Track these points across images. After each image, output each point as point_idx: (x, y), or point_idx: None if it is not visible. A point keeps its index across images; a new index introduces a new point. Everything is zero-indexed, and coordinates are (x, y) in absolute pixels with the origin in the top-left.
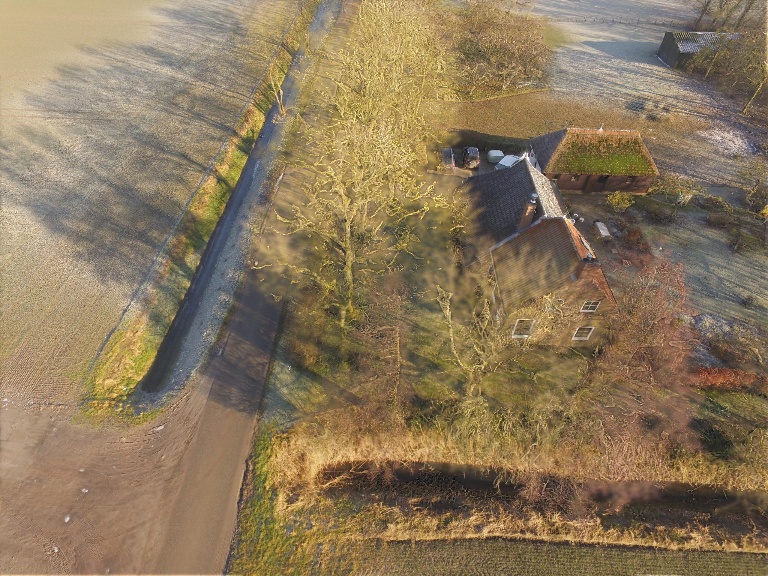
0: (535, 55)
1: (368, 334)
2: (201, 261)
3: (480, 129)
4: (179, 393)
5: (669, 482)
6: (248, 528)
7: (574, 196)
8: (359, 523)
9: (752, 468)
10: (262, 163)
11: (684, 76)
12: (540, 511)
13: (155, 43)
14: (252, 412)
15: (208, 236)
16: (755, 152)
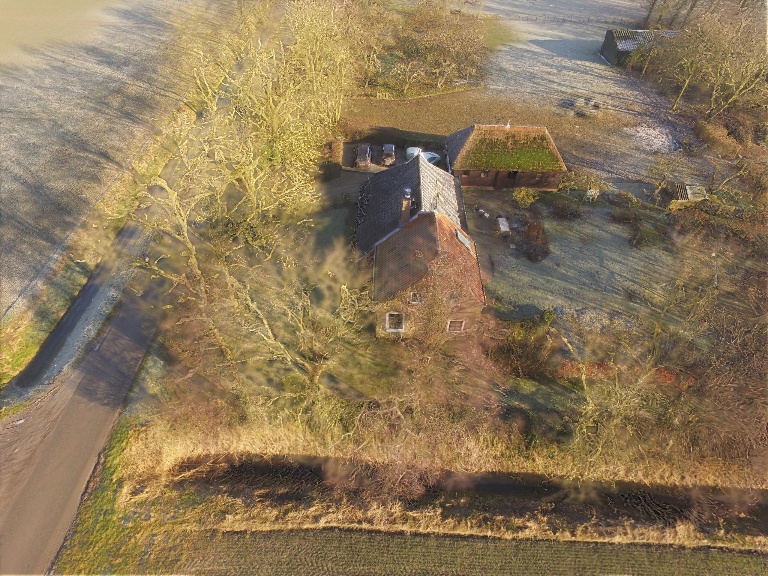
0: (470, 53)
1: (248, 329)
2: (103, 258)
3: (406, 127)
4: (47, 388)
5: (525, 473)
6: (86, 520)
7: (485, 192)
8: (198, 514)
9: (581, 457)
10: (182, 161)
11: (623, 74)
12: (382, 502)
13: (99, 43)
14: (115, 406)
15: (114, 233)
16: (677, 148)
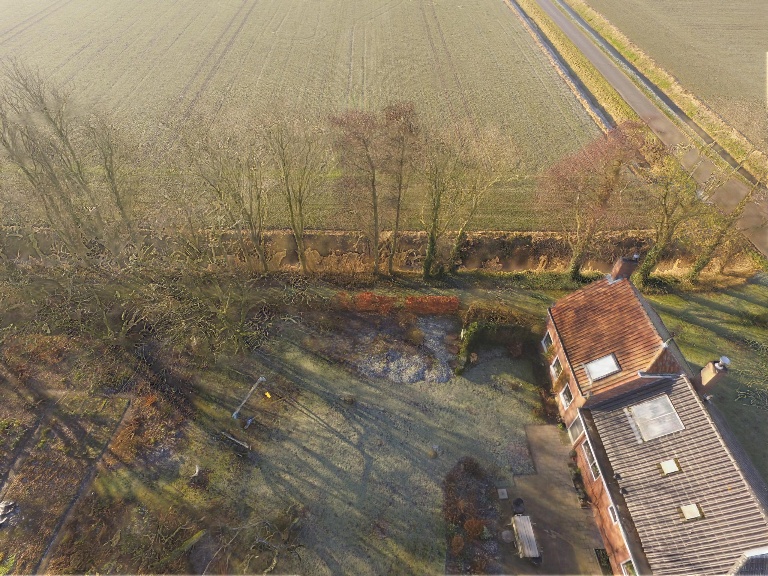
0: None
1: (761, 344)
2: None
3: None
4: None
5: None
6: None
7: None
8: None
9: None
10: None
11: None
12: None
13: None
14: None
15: None
16: None
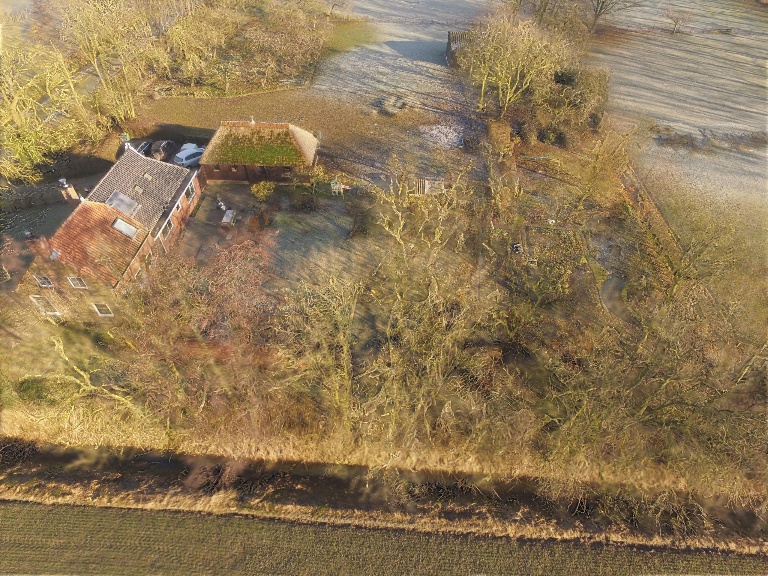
0: (294, 54)
1: None
2: None
3: (206, 124)
4: None
5: (125, 447)
6: None
7: (238, 186)
8: None
9: None
10: None
11: (455, 74)
12: None
13: None
14: None
15: None
16: (459, 145)
